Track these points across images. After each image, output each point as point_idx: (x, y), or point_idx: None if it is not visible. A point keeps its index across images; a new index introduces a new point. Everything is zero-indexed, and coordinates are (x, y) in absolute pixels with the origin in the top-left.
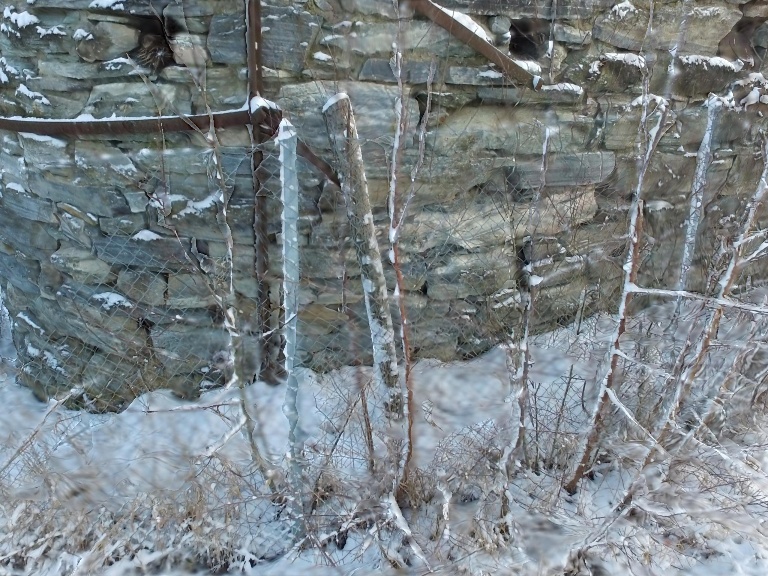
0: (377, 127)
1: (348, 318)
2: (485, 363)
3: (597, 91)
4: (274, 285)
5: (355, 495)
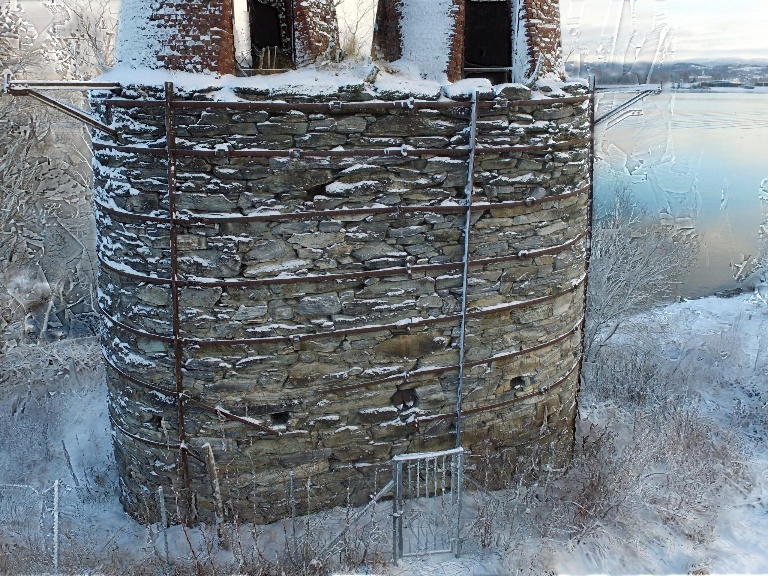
0: None
1: None
2: (272, 527)
3: None
4: None
5: (187, 575)
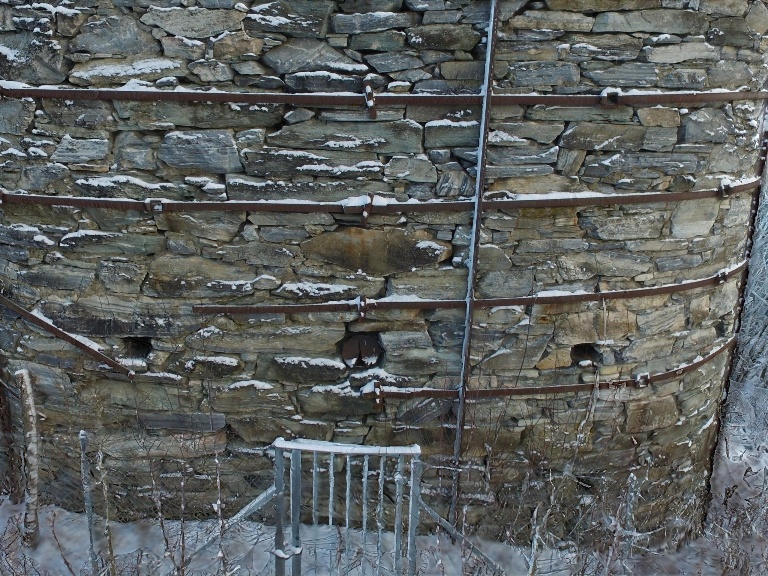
0: (49, 385)
1: (54, 478)
2: (122, 529)
3: (199, 377)
4: (22, 450)
5: None
